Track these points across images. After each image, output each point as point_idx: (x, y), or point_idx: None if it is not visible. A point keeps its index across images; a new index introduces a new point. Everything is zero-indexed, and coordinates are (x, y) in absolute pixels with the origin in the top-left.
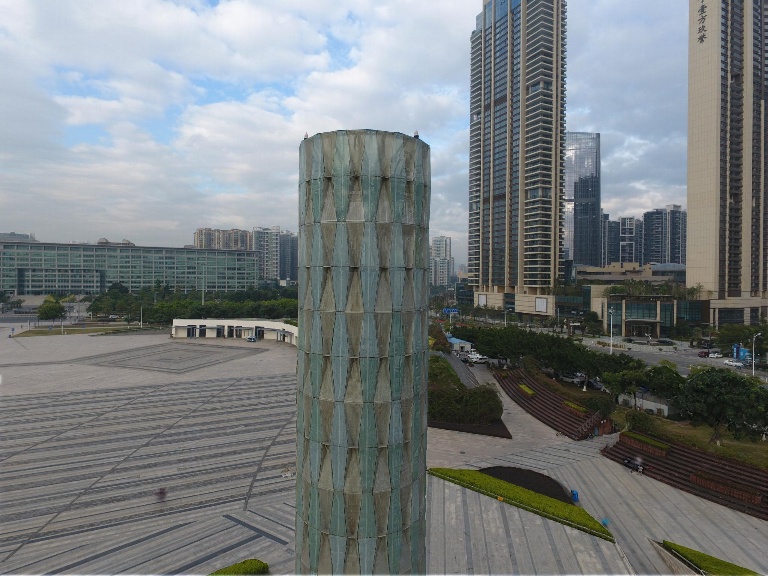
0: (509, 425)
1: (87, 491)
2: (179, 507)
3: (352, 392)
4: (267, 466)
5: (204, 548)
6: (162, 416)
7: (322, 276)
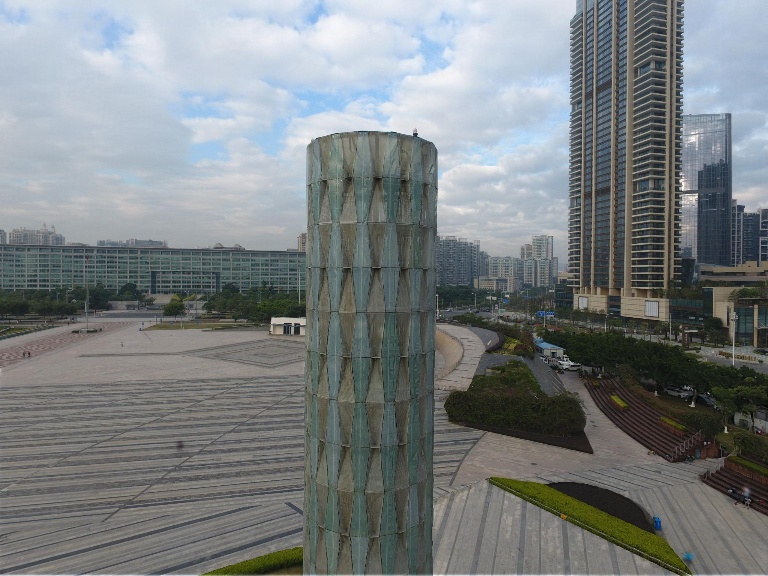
0: (593, 439)
1: (176, 468)
2: (249, 491)
3: (345, 391)
4: None
5: (263, 531)
6: (249, 406)
7: (319, 277)
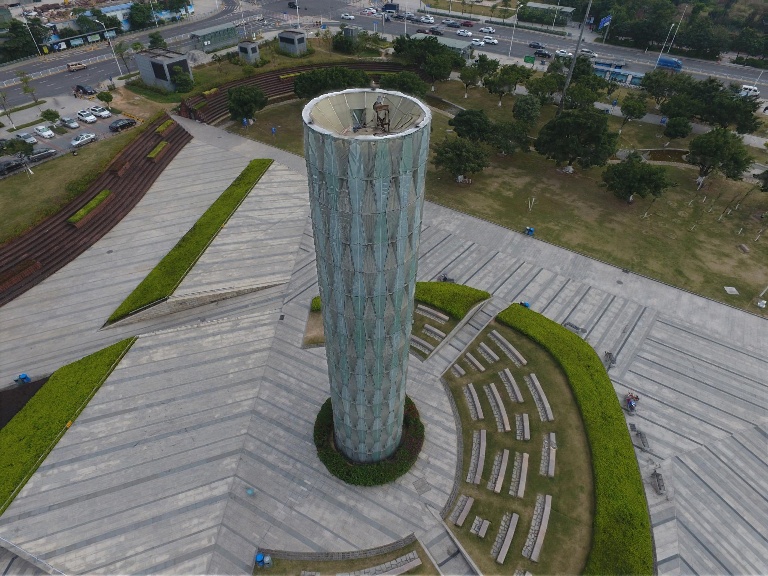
0: None
1: None
2: None
3: None
4: None
5: None
6: None
7: None
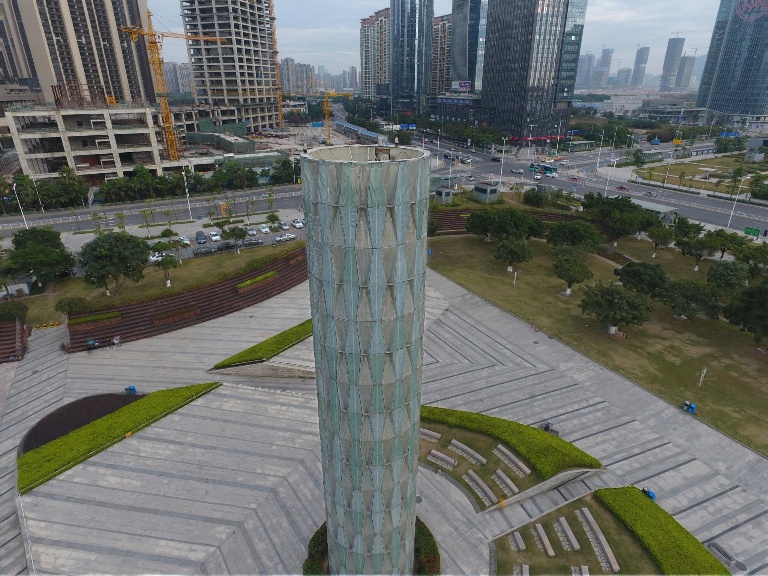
0: None
1: None
2: None
3: None
4: None
5: None
6: None
7: None
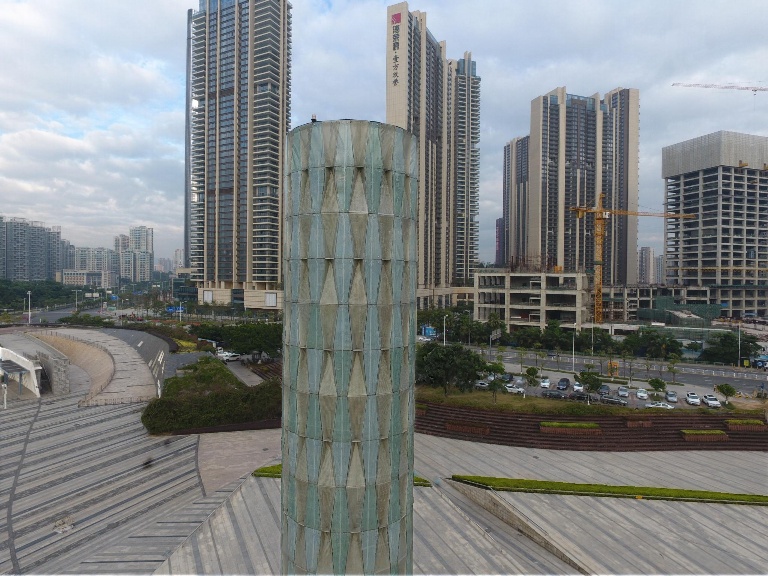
0: None
1: None
2: None
3: (382, 384)
4: (23, 527)
5: None
6: None
7: (352, 269)
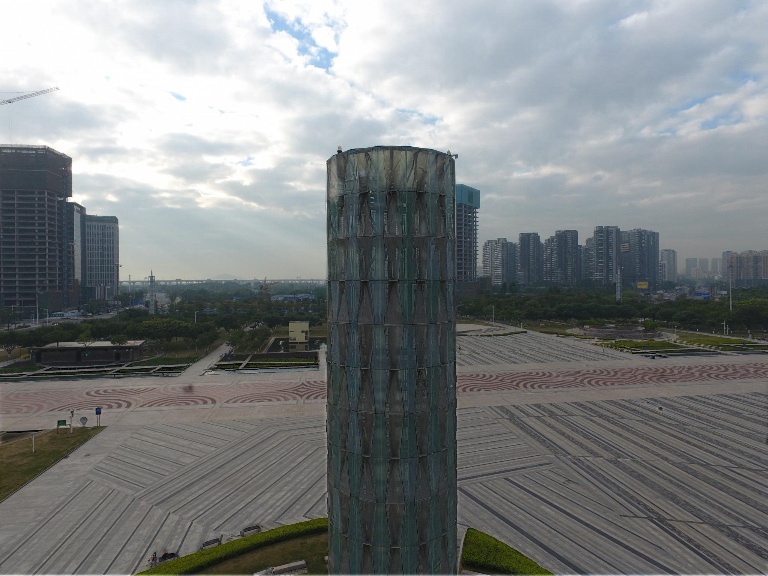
0: None
1: (759, 529)
2: None
3: None
4: None
5: None
6: None
7: None
